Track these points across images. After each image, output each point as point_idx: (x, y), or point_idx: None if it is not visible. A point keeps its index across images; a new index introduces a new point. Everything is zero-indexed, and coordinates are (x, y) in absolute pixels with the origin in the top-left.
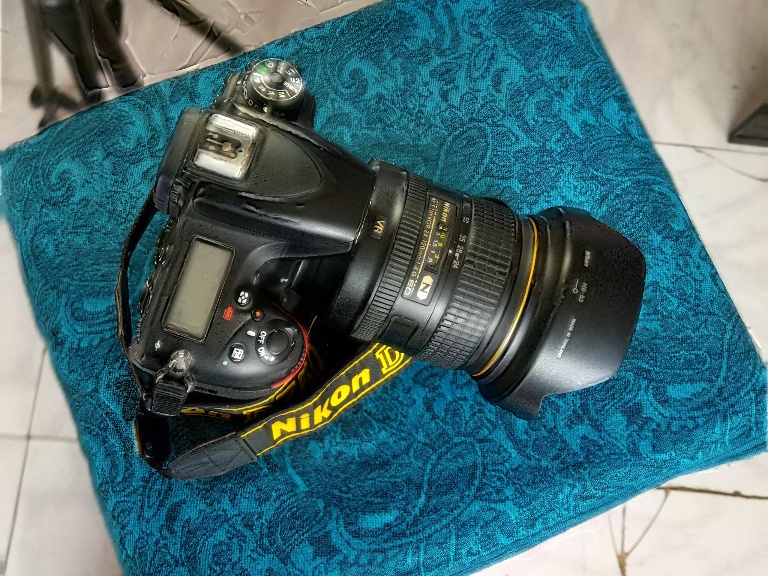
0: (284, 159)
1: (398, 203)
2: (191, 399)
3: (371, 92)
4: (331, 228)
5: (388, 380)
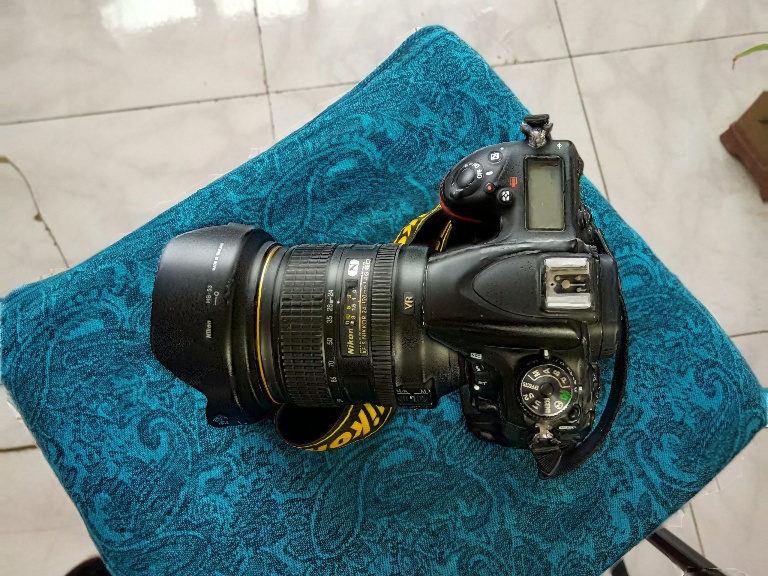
0: (512, 292)
1: (397, 333)
2: None
3: (452, 564)
4: (451, 258)
5: None
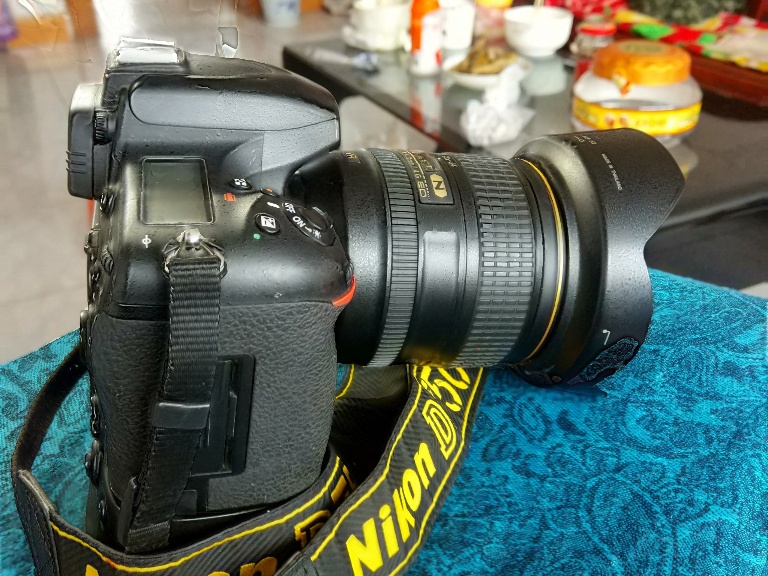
0: (220, 59)
1: None
2: None
3: None
4: (306, 102)
5: (455, 473)
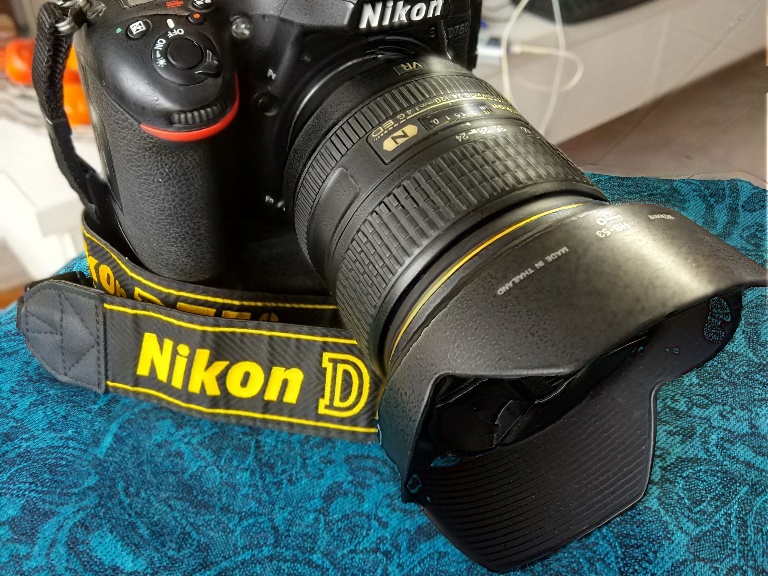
0: None
1: None
2: (111, 237)
3: None
4: None
5: (319, 433)
